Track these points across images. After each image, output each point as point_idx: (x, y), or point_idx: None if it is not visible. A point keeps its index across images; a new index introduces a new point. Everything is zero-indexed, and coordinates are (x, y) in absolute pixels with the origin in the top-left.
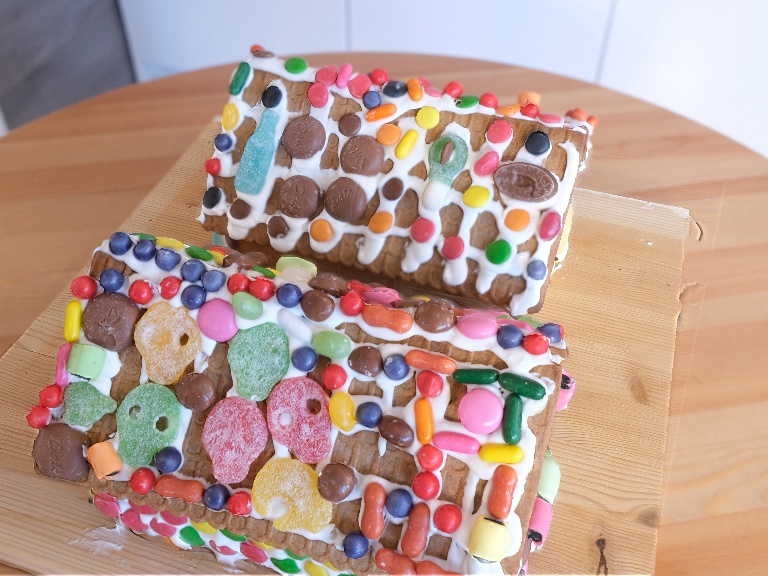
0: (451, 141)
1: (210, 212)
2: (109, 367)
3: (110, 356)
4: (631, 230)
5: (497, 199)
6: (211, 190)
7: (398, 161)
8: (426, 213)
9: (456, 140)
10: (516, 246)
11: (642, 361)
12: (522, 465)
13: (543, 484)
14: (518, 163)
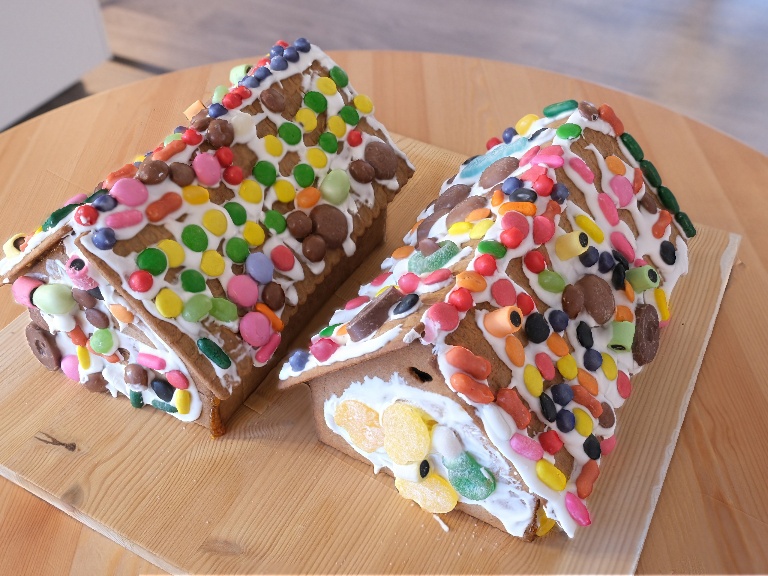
0: None
1: None
2: None
3: None
4: None
5: None
6: None
7: None
8: None
9: (440, 249)
10: None
11: (263, 569)
12: None
13: None
14: (387, 293)
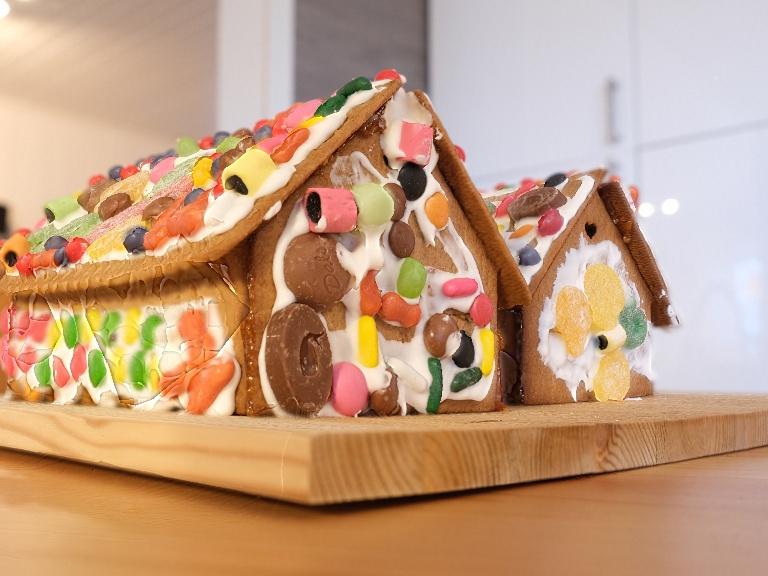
0: None
1: None
2: (74, 215)
3: (81, 210)
4: (757, 396)
5: (511, 231)
6: None
7: None
8: None
9: None
10: (516, 253)
11: (696, 410)
12: (317, 125)
13: (356, 188)
14: None
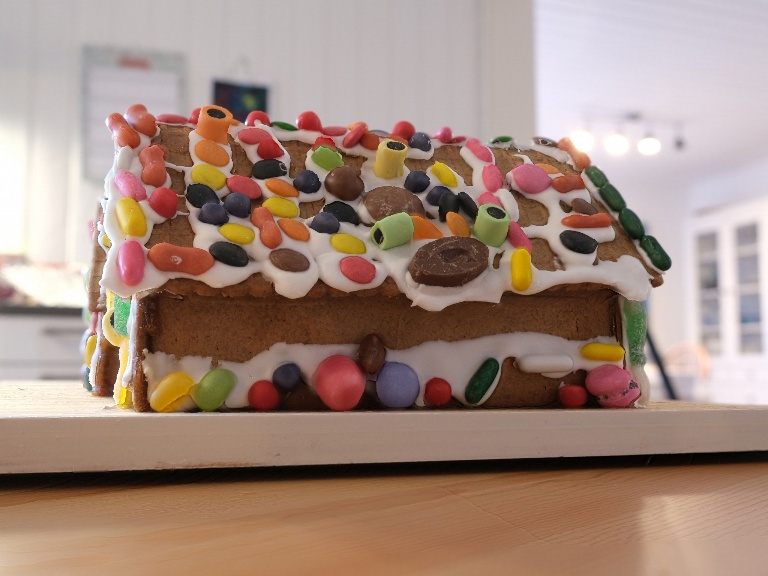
0: None
1: None
2: None
3: None
4: None
5: None
6: None
7: None
8: None
9: None
10: None
11: None
12: None
13: None
14: None
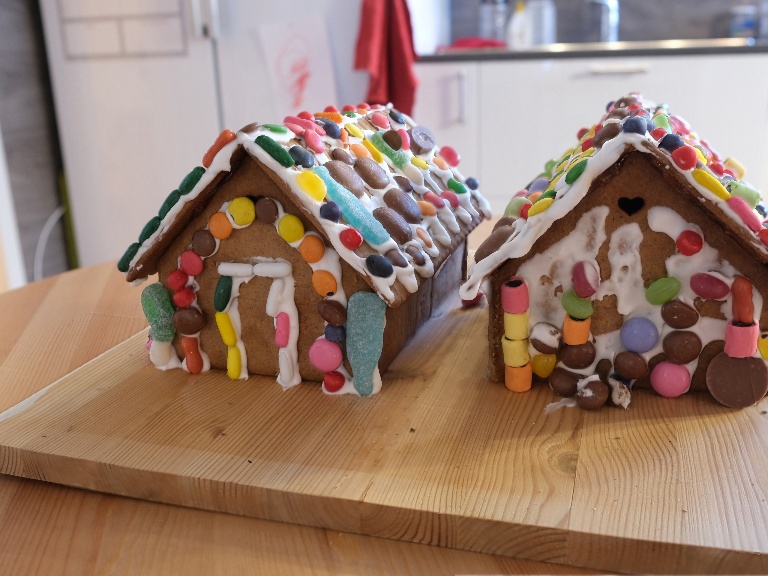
0: (388, 131)
1: (394, 278)
2: None
3: None
4: None
5: None
6: (376, 257)
7: (383, 165)
8: (425, 187)
9: None
10: None
11: None
12: None
13: None
14: (413, 128)
